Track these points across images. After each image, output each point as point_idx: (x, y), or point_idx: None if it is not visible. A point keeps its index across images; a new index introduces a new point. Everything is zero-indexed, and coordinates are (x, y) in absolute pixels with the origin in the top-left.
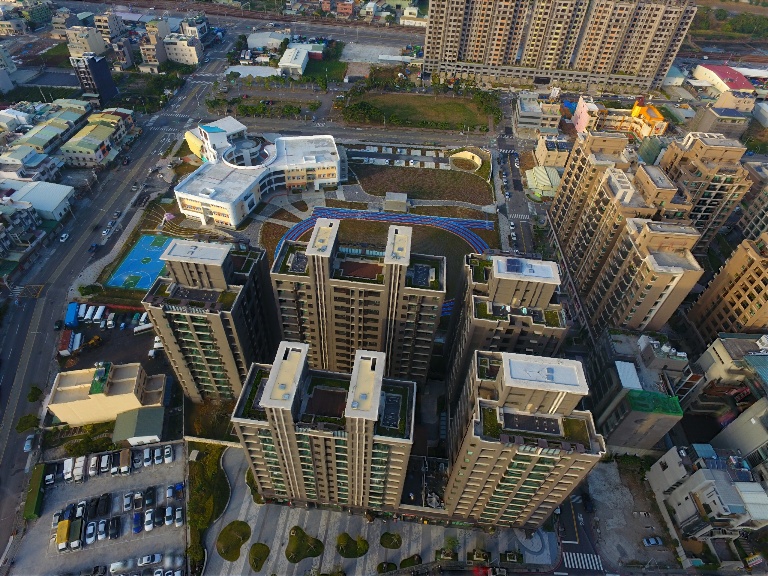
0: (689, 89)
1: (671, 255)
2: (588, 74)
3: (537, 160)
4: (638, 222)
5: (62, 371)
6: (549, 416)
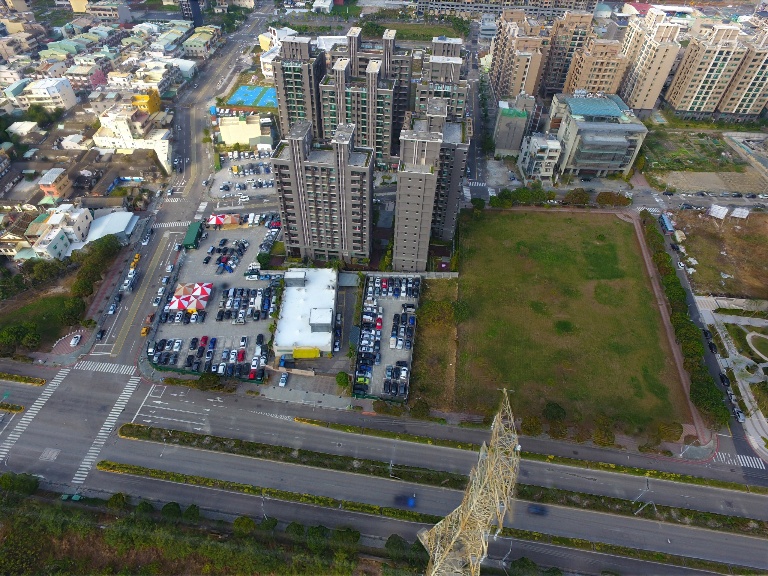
0: (615, 19)
1: (530, 52)
2: (538, 8)
3: None
4: None
5: (214, 131)
6: None
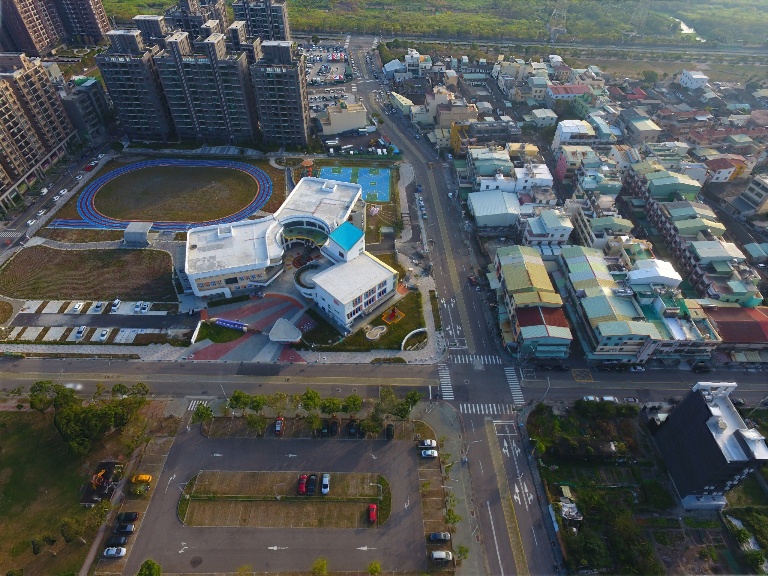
0: None
1: None
2: None
3: None
4: None
5: None
6: None
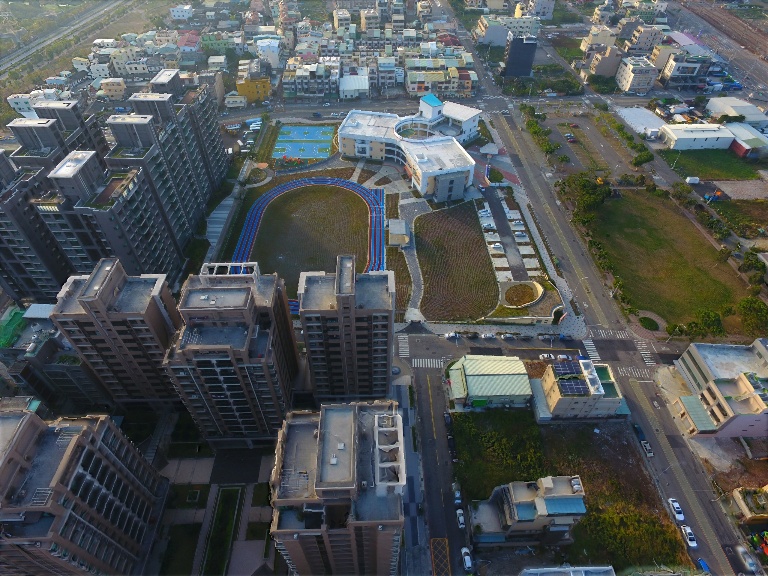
0: None
1: None
2: None
3: None
4: None
5: None
6: None
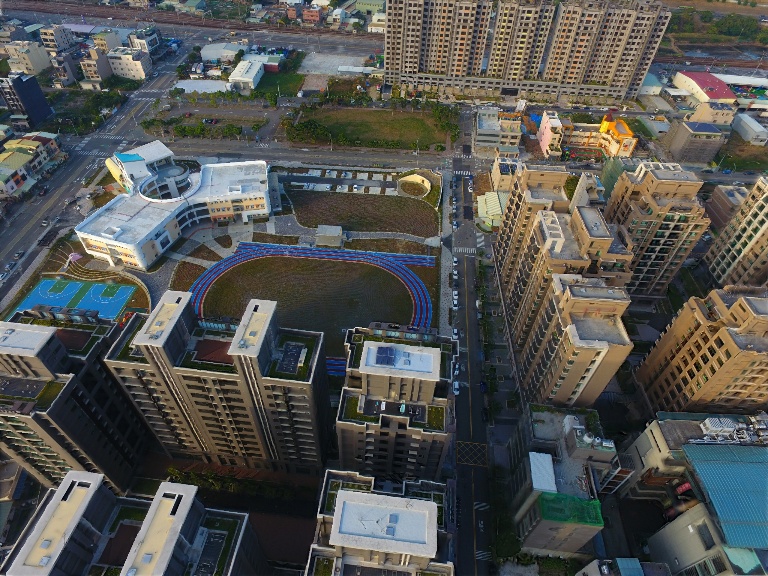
0: (667, 99)
1: (599, 322)
2: (558, 84)
3: (492, 183)
4: (565, 279)
5: None
6: (402, 568)
